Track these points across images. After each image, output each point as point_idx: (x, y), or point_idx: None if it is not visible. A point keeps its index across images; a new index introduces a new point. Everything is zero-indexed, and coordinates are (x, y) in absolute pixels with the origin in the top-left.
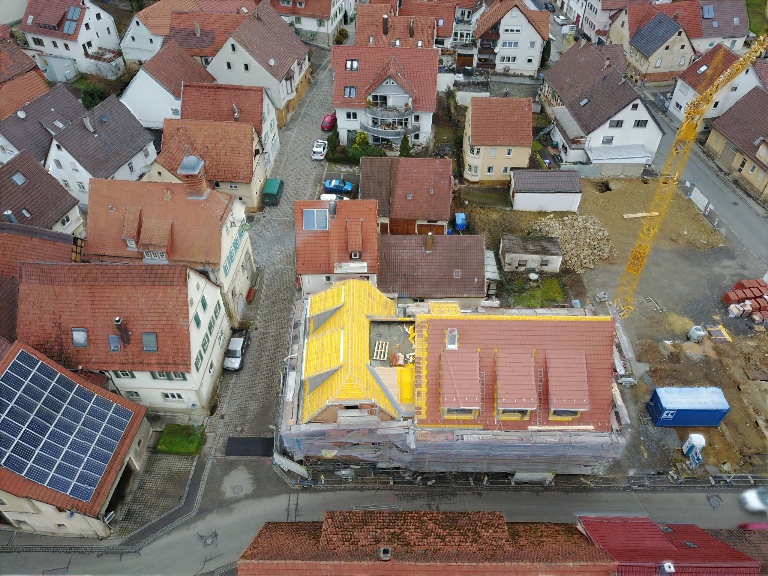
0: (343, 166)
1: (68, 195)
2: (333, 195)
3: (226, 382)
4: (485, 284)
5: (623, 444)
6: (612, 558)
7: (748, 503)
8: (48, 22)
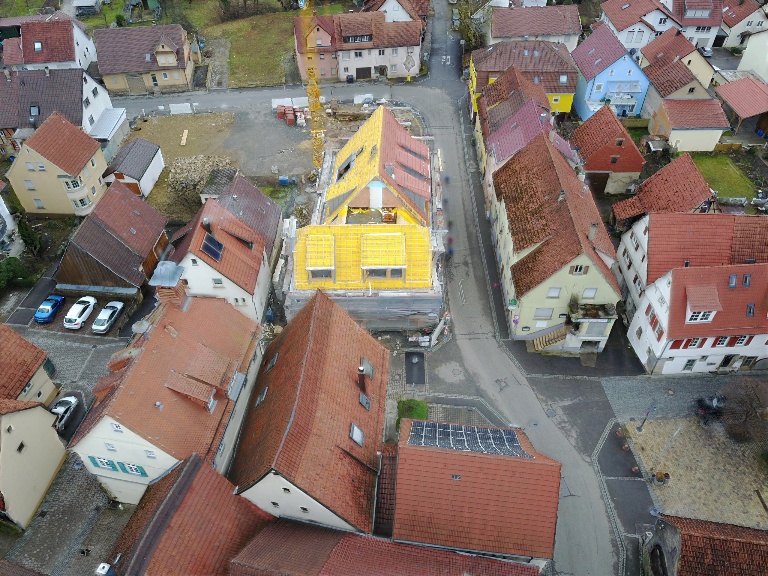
0: (1, 307)
1: None
2: (74, 307)
3: None
4: None
5: None
6: None
7: None
8: None
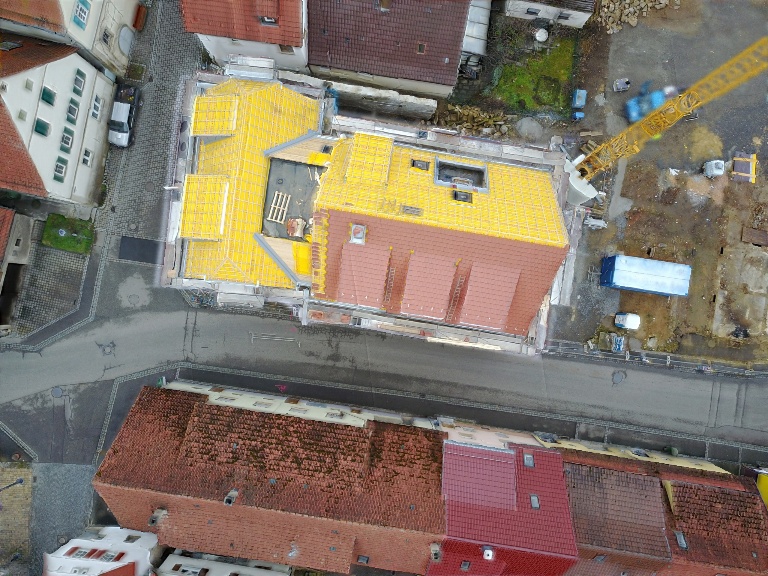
0: None
1: None
2: None
3: (115, 161)
4: (463, 56)
5: (531, 356)
6: (444, 526)
7: (651, 383)
8: None
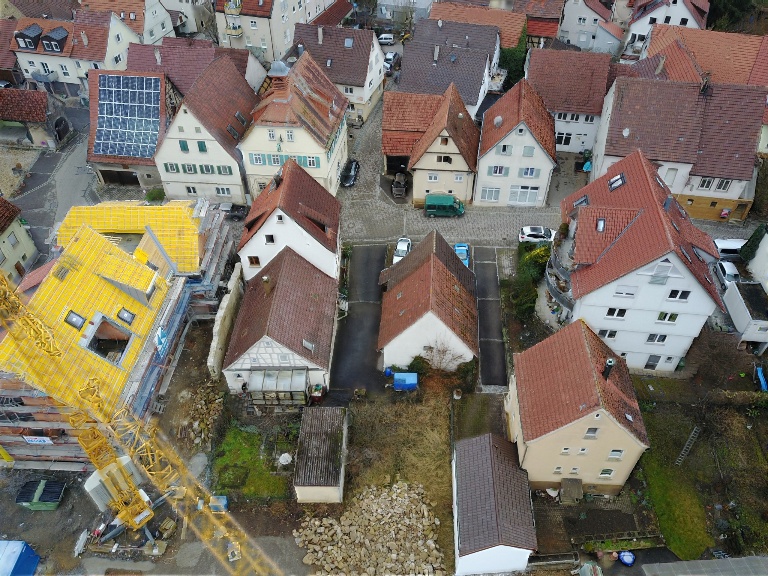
0: (512, 262)
1: (364, 78)
2: None
3: None
4: None
5: None
6: None
7: None
8: (639, 1)
